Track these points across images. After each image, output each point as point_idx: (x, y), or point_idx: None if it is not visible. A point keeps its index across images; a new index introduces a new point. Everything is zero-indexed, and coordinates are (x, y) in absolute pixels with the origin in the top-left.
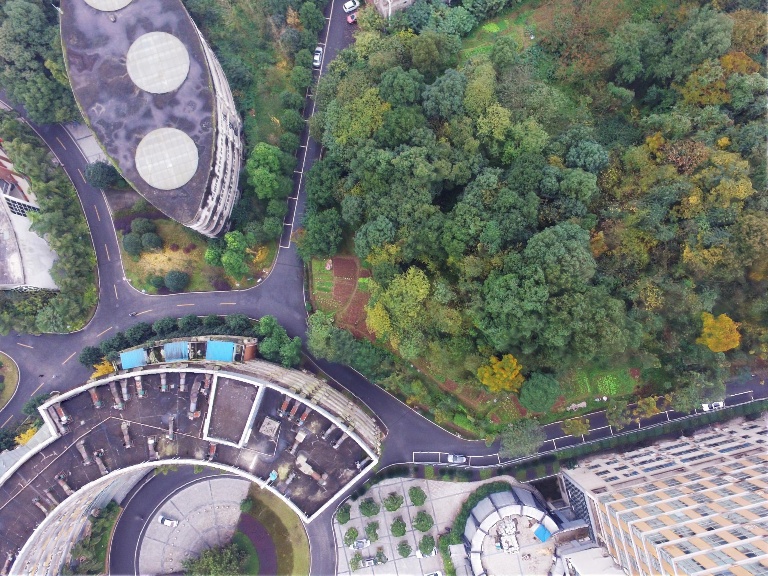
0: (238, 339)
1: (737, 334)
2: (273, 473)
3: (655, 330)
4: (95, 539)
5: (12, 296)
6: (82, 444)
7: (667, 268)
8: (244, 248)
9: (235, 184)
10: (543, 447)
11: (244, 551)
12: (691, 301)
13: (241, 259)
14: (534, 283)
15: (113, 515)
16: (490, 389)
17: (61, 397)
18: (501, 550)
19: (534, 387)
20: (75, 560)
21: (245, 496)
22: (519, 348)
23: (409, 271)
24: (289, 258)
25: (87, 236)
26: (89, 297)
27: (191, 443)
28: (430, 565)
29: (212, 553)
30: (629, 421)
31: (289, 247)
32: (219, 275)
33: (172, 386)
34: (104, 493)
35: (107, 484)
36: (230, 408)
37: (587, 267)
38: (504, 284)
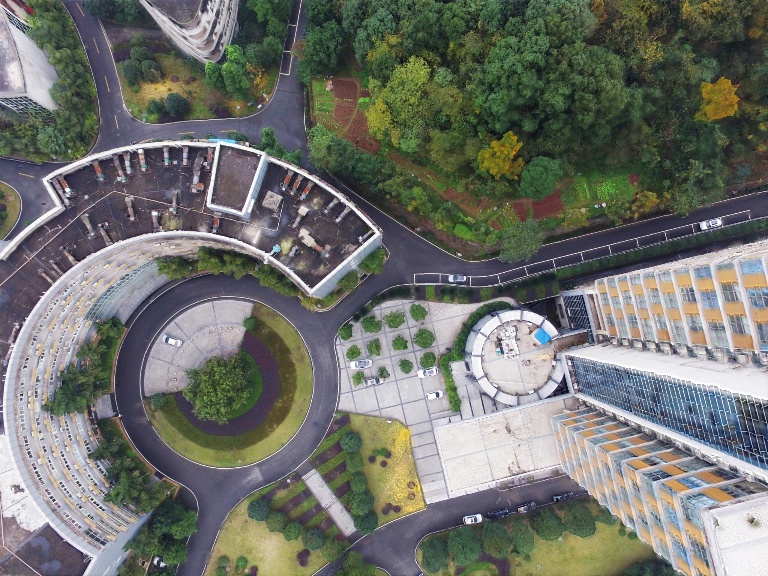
0: (240, 141)
1: (735, 97)
2: (276, 246)
3: (654, 119)
4: (100, 346)
5: (13, 116)
6: (86, 216)
7: (666, 42)
8: (244, 63)
9: (234, 12)
10: (543, 267)
11: (248, 366)
12: (690, 72)
13: (241, 71)
14: (535, 35)
15: (118, 334)
16: (491, 171)
17: (65, 168)
18: (501, 356)
19: (534, 166)
20: (81, 369)
21: (248, 317)
22: (519, 126)
23: (410, 59)
24: (289, 85)
25: (86, 67)
26: (90, 124)
27: (195, 218)
28: (431, 385)
29: (216, 359)
30: (628, 214)
31: (289, 74)
32: (219, 103)
33: (175, 162)
34: (108, 305)
35: (111, 282)
36: (233, 177)
37: (587, 16)
38: (505, 44)
